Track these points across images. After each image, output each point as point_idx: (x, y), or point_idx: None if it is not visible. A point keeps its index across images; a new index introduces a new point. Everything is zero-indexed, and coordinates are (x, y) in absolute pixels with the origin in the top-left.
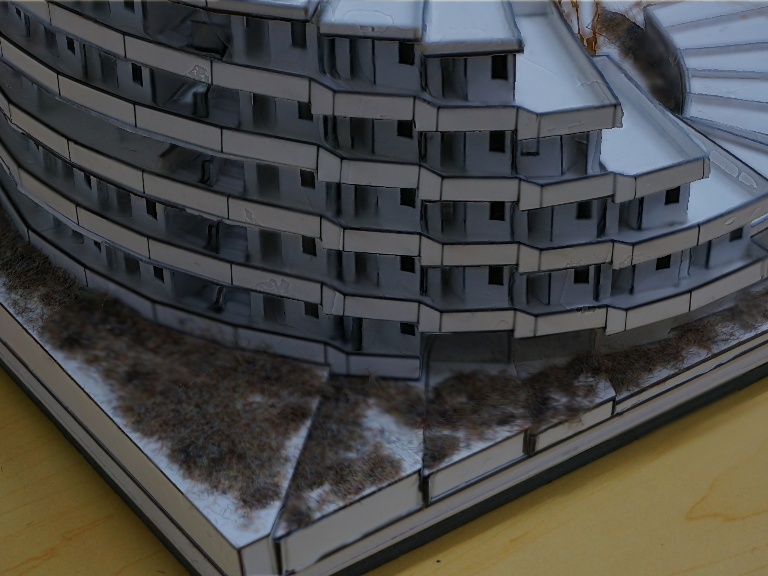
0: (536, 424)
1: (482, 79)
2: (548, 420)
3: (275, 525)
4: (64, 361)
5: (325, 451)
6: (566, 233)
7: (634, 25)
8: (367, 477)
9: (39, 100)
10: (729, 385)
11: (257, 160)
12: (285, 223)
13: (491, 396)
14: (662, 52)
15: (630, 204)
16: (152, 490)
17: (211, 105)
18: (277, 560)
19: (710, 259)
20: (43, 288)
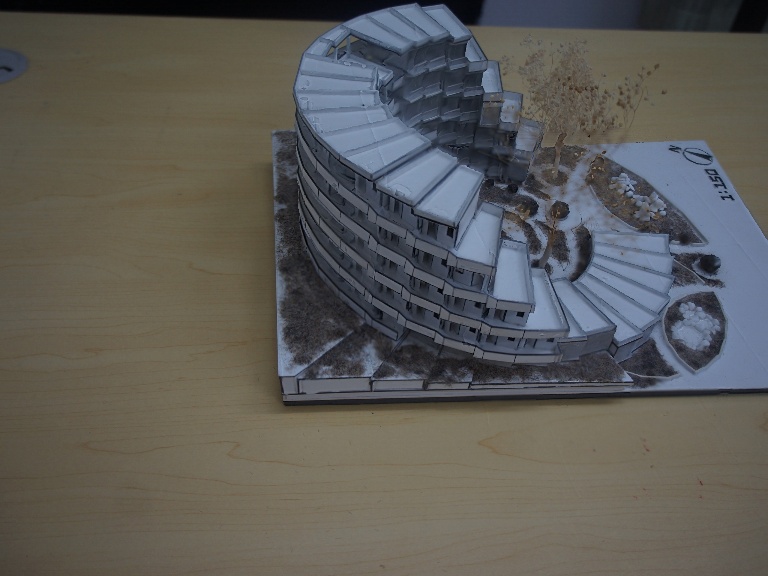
0: (431, 379)
1: (443, 233)
2: (437, 379)
3: (301, 373)
4: (278, 276)
5: (341, 353)
6: (469, 310)
7: (589, 236)
8: (348, 371)
9: None
10: (532, 396)
11: (350, 230)
12: (357, 259)
13: (420, 360)
14: (590, 251)
15: None
16: None
17: (346, 201)
18: (298, 387)
19: (536, 345)
20: (293, 246)
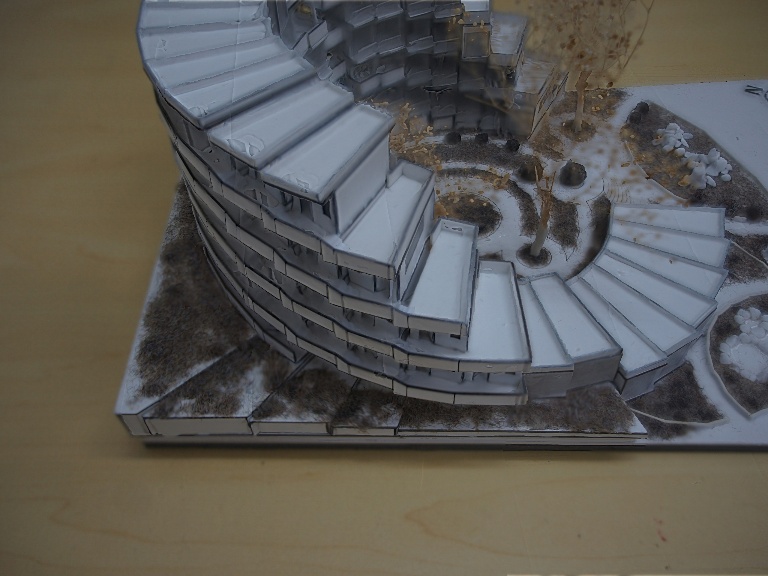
0: (336, 422)
1: (318, 211)
2: (346, 422)
3: (148, 409)
4: (156, 266)
5: (212, 380)
6: (382, 325)
7: None
8: (214, 407)
9: None
10: (496, 446)
11: None
12: None
13: (325, 392)
14: (606, 232)
15: None
16: None
17: None
18: None
19: (489, 377)
20: (188, 225)
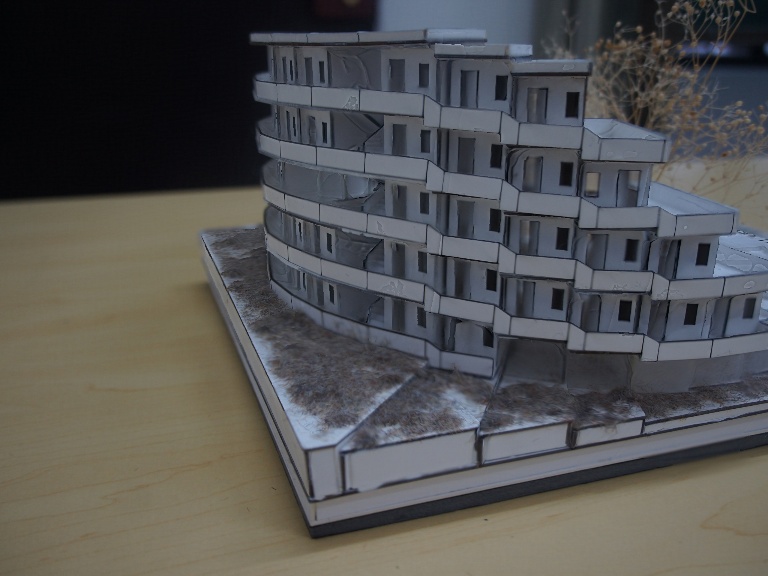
0: (578, 421)
1: (558, 118)
2: (589, 421)
3: (345, 442)
4: (254, 338)
5: (405, 405)
6: None
7: None
8: (431, 424)
9: (283, 187)
10: (733, 443)
11: (387, 177)
12: (403, 232)
13: (545, 397)
14: None
15: (667, 262)
16: (279, 422)
17: (366, 151)
18: (342, 474)
19: (726, 329)
20: None
